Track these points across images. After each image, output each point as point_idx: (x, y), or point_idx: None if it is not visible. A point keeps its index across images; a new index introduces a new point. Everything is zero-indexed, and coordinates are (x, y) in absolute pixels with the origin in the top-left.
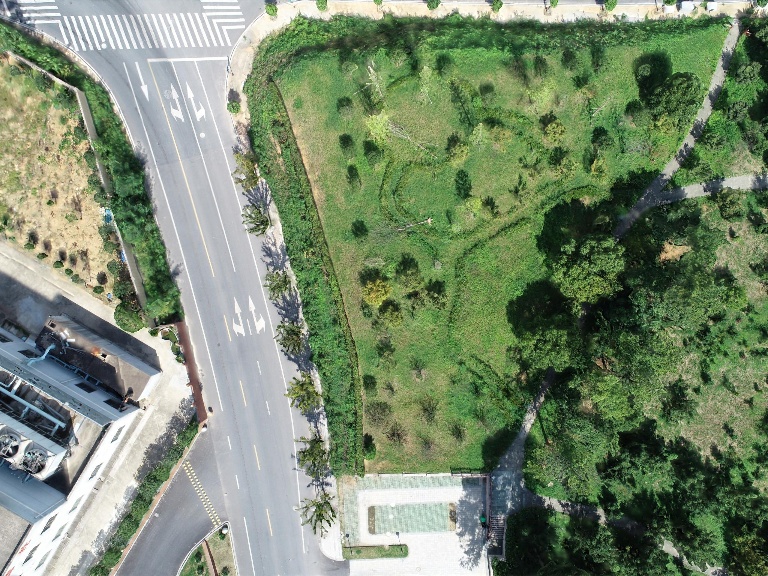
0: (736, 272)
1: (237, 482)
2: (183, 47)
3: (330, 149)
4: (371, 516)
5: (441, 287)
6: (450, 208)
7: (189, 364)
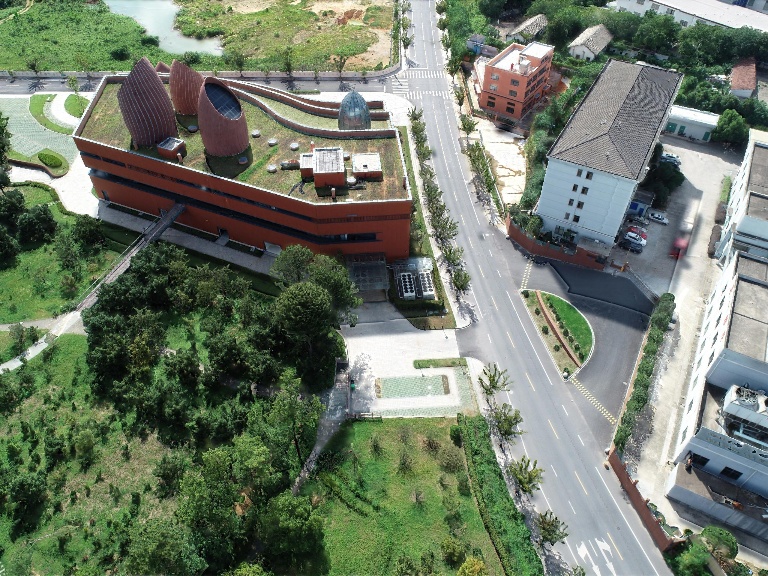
0: None
1: (565, 410)
2: None
3: None
4: (447, 387)
5: None
6: None
7: (642, 505)
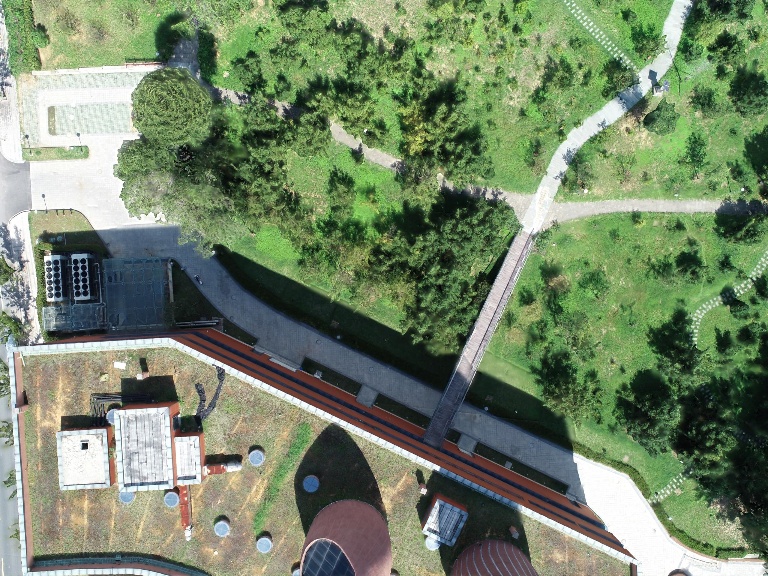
0: None
1: None
2: None
3: None
4: (51, 116)
5: None
6: None
7: None
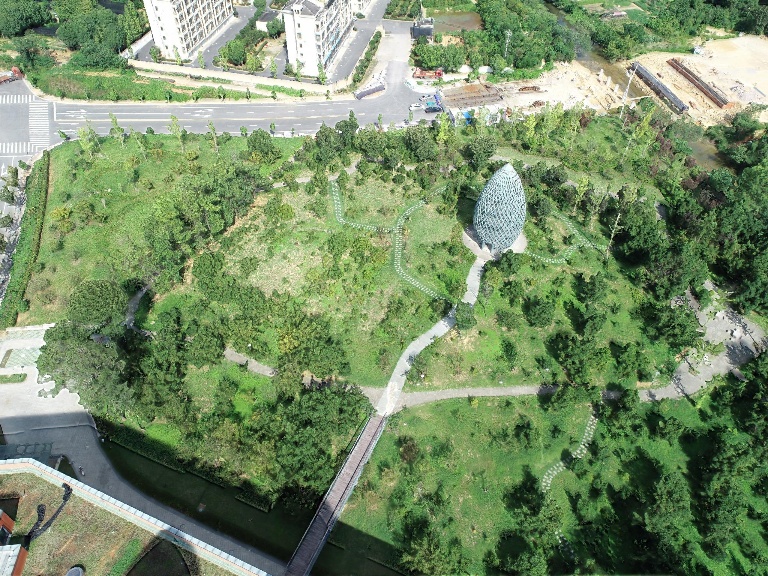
0: (295, 209)
1: None
2: (10, 153)
3: (65, 170)
4: (7, 356)
5: (106, 218)
6: (124, 186)
7: None
